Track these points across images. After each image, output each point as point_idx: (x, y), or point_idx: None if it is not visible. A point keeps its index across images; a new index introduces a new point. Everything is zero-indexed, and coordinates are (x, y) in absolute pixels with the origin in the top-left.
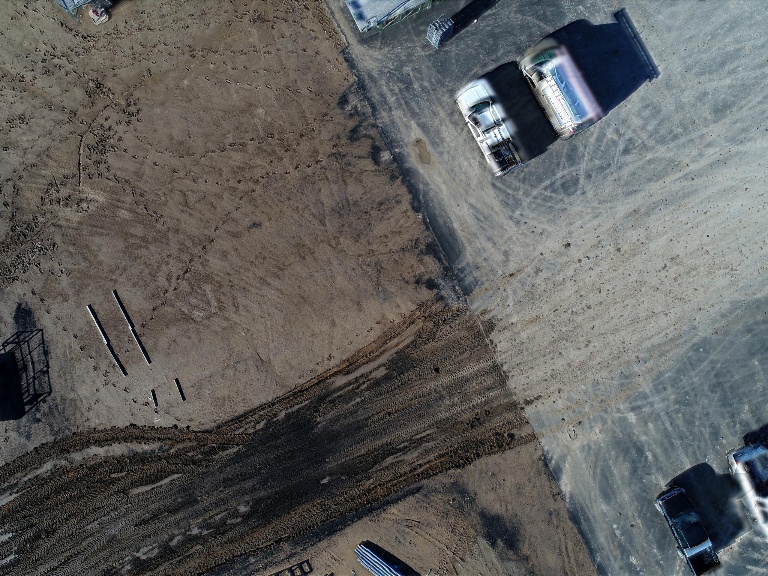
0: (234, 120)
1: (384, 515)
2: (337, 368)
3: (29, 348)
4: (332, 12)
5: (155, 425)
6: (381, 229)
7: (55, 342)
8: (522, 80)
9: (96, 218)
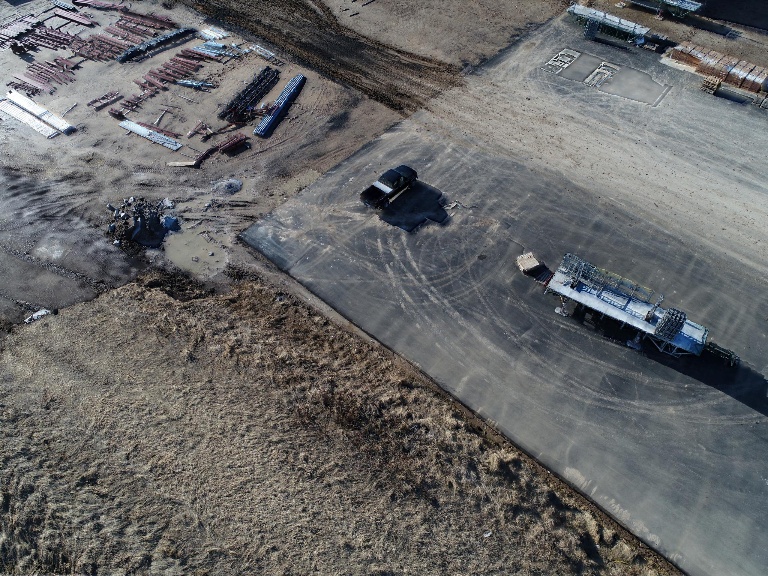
0: (493, 2)
1: (325, 81)
2: None
3: None
4: None
5: None
6: None
7: None
8: None
9: None
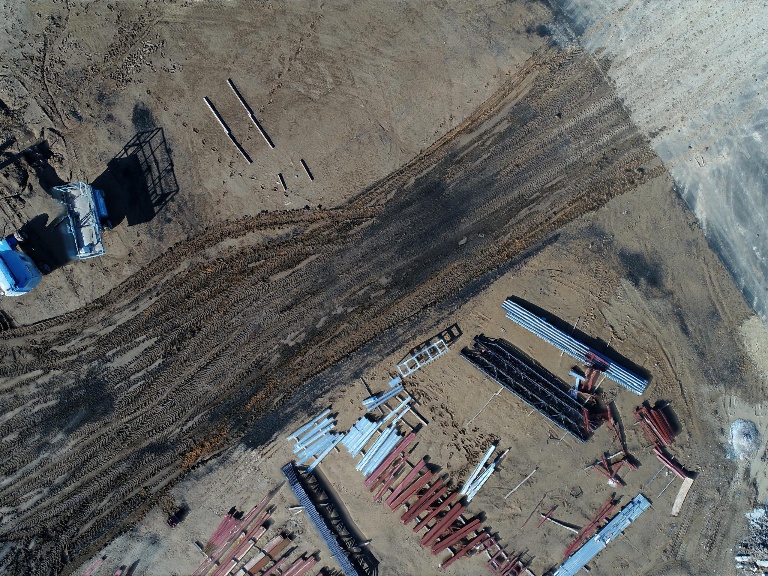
0: None
1: (526, 268)
2: (460, 128)
3: (151, 148)
4: None
5: (287, 209)
6: None
7: (176, 139)
8: None
9: (201, 10)
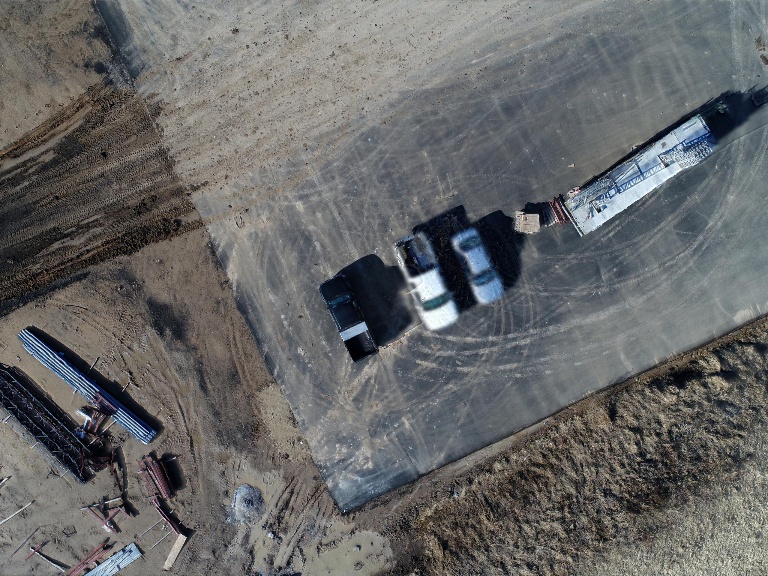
0: None
1: (51, 301)
2: (5, 151)
3: None
4: None
5: None
6: (50, 11)
7: None
8: None
9: None
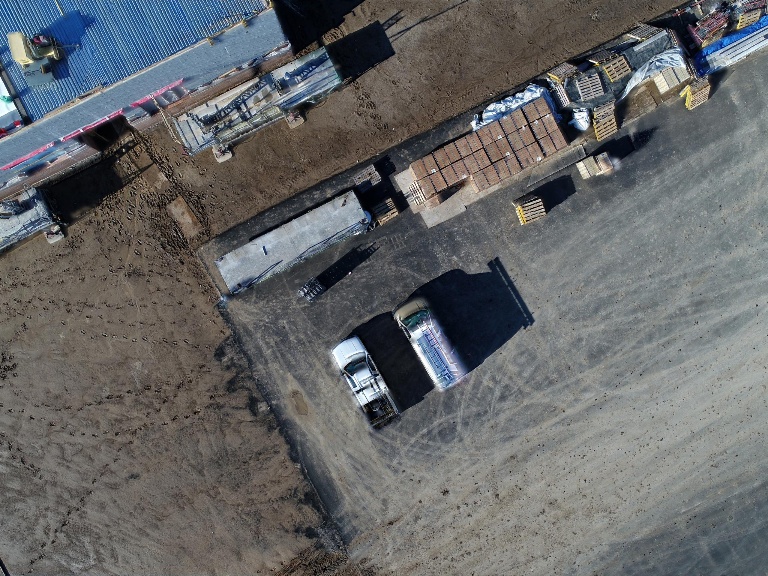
0: (111, 373)
1: None
2: None
3: None
4: (206, 267)
5: None
6: (260, 479)
7: None
8: (397, 330)
9: None
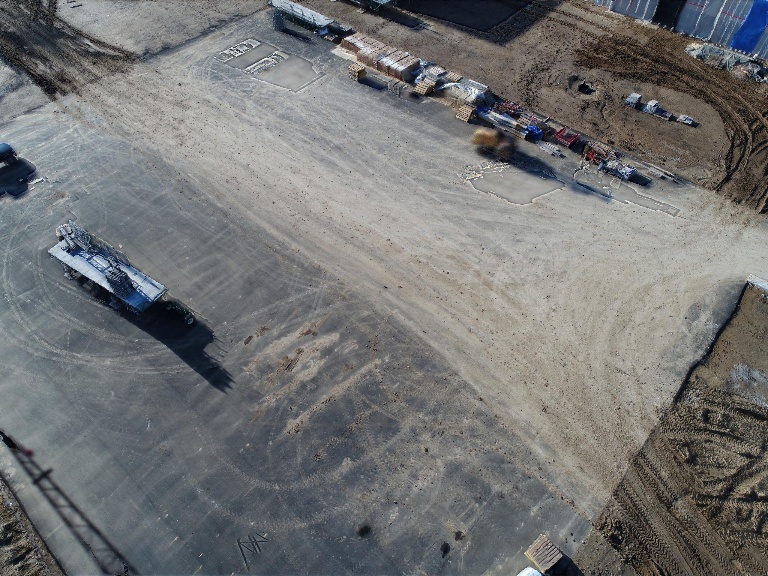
0: None
1: (3, 67)
2: None
3: None
4: None
5: (57, 4)
6: None
7: None
8: None
9: None
